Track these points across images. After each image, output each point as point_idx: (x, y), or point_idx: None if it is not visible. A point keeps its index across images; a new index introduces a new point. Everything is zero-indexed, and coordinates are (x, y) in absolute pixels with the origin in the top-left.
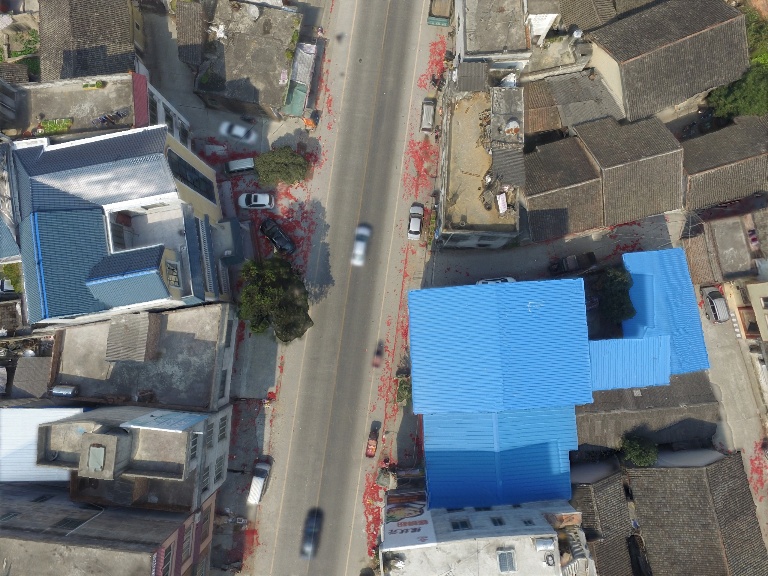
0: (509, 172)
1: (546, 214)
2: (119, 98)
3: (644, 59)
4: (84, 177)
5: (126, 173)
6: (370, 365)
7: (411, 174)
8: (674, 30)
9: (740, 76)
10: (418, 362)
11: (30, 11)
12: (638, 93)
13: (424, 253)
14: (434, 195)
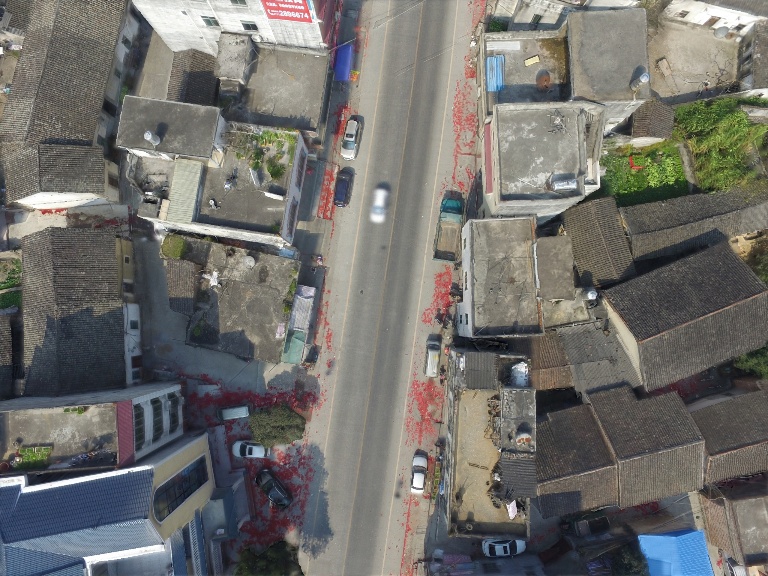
0: (520, 484)
1: (558, 496)
2: (103, 423)
3: (663, 336)
4: (63, 540)
5: (108, 534)
6: None
7: (414, 418)
8: (695, 301)
9: (764, 344)
10: None
11: (14, 239)
12: (656, 366)
13: (428, 506)
14: (439, 446)
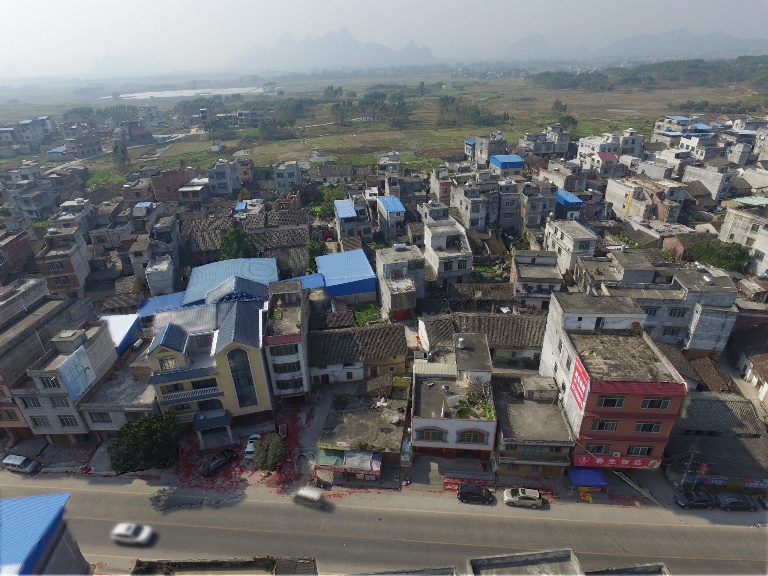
0: None
1: None
2: None
3: None
4: None
5: None
6: None
7: None
8: None
9: None
10: (1, 504)
11: None
12: None
13: None
14: None
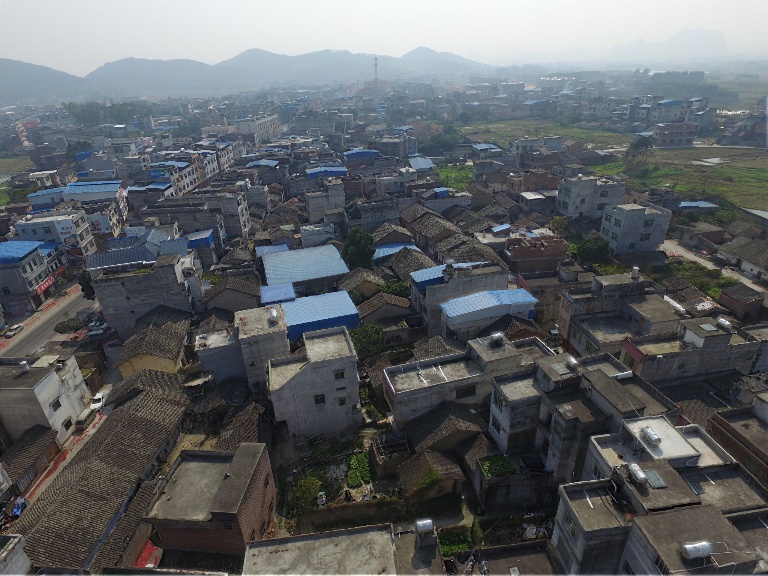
0: None
1: None
2: None
3: None
4: None
5: None
6: (77, 295)
7: None
8: None
9: None
10: None
11: None
12: None
13: None
14: None
